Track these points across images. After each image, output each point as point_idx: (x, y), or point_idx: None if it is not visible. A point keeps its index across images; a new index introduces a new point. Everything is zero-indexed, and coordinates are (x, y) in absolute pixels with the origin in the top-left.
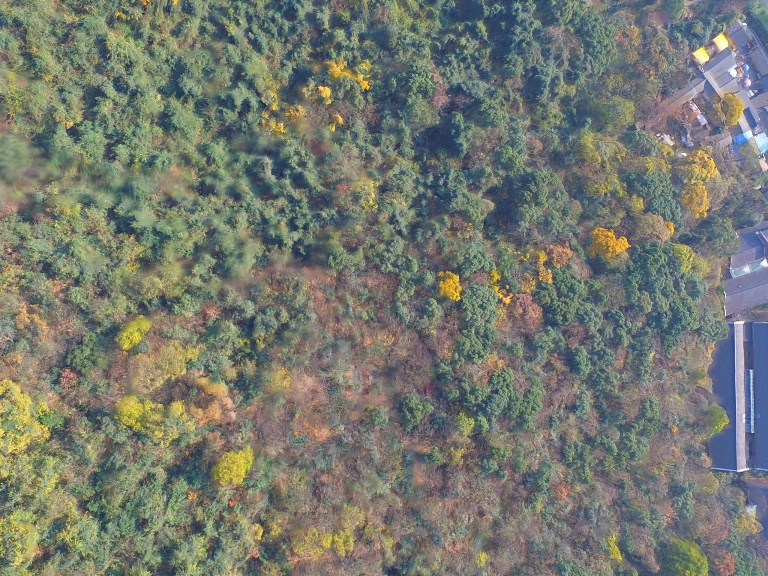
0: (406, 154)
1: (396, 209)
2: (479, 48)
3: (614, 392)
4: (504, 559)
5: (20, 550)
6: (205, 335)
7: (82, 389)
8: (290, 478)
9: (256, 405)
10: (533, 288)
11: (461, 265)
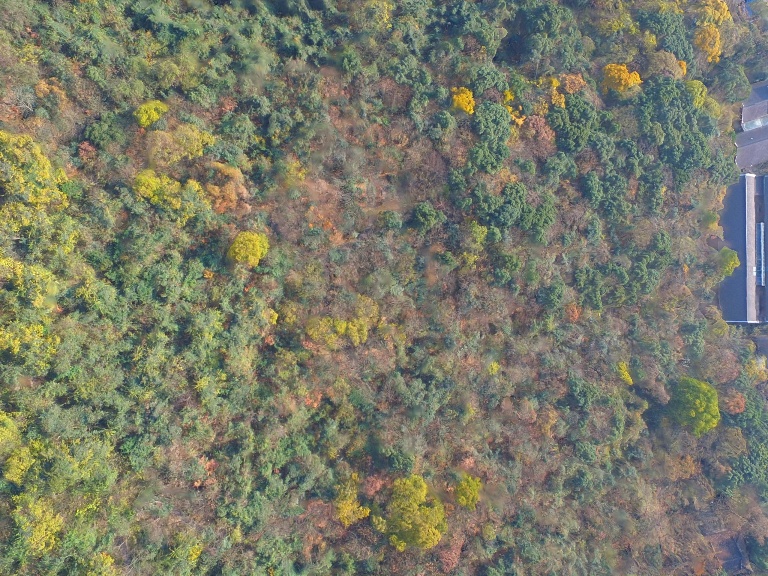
0: None
1: (410, 29)
2: None
3: (626, 223)
4: (516, 369)
5: (41, 293)
6: (221, 126)
7: (100, 159)
8: (305, 267)
9: (271, 206)
10: (546, 111)
11: (474, 81)
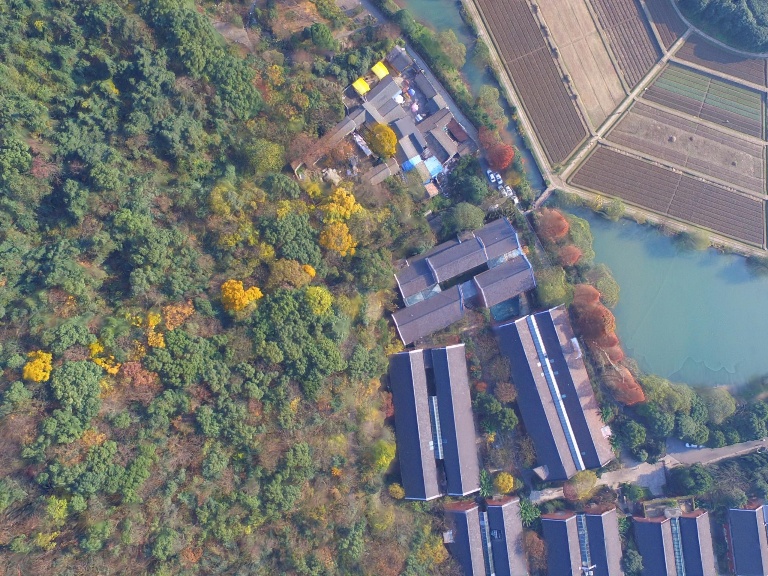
0: (27, 227)
1: None
2: (107, 107)
3: (253, 445)
4: None
5: None
6: None
7: None
8: None
9: None
10: (143, 354)
11: (51, 343)
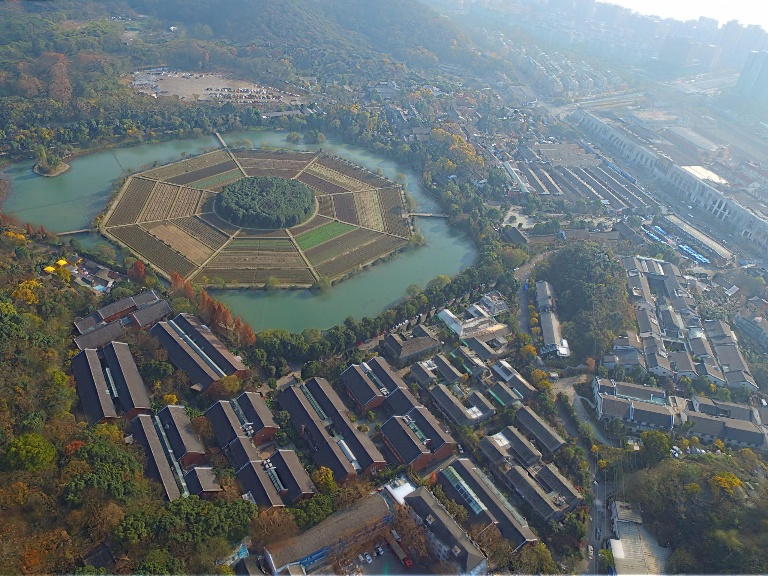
0: None
1: None
2: None
3: None
4: None
5: None
6: None
7: None
8: None
9: None
10: None
11: None
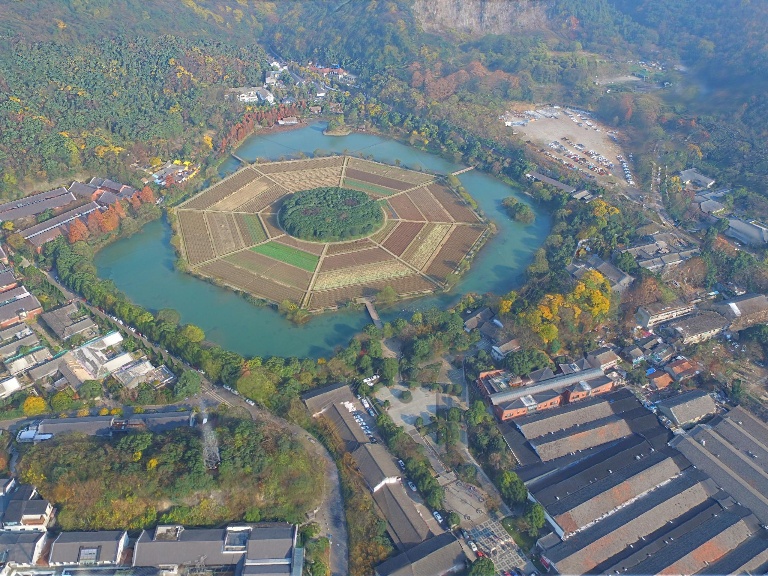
0: None
1: (38, 96)
2: None
3: None
4: None
5: None
6: None
7: None
8: None
9: None
10: None
11: None
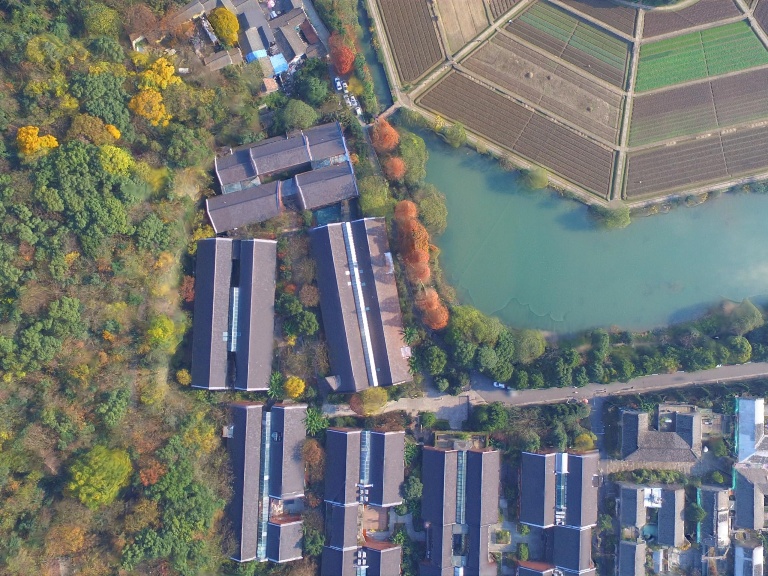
0: None
1: None
2: None
3: (18, 289)
4: None
5: None
6: None
7: None
8: None
9: None
10: None
11: None
